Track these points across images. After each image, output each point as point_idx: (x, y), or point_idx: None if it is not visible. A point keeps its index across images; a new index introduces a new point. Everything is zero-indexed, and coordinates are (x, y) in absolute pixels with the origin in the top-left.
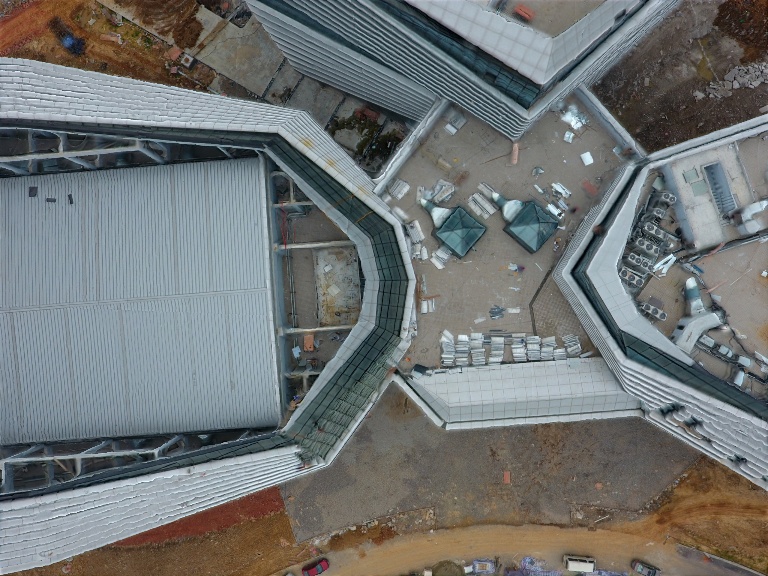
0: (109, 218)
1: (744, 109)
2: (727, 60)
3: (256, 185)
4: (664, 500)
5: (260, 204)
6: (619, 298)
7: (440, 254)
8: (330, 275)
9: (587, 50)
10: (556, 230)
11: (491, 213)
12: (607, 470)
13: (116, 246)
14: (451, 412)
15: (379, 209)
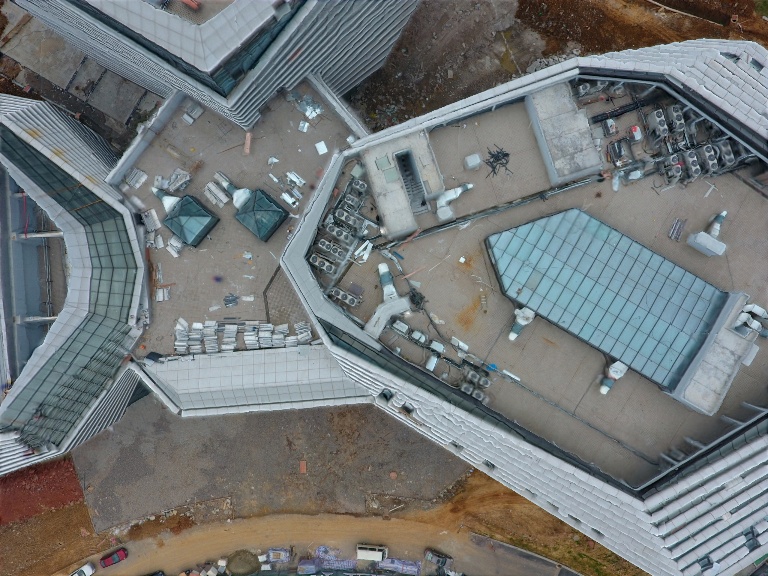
0: None
1: None
2: (529, 52)
3: None
4: (458, 489)
5: None
6: (308, 284)
7: (173, 242)
8: None
9: (268, 38)
10: (290, 218)
11: (224, 202)
12: (402, 459)
13: None
14: (182, 399)
15: (107, 198)
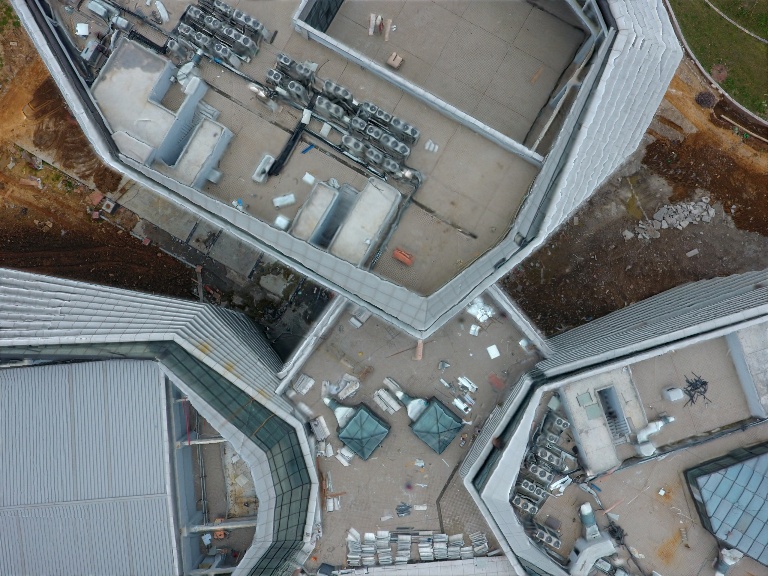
0: (6, 420)
1: (671, 253)
2: (656, 198)
3: (156, 386)
4: None
5: (160, 406)
6: (512, 527)
7: (345, 452)
8: (238, 465)
9: None
10: (463, 425)
11: (396, 410)
12: None
13: (13, 450)
14: None
15: (280, 412)
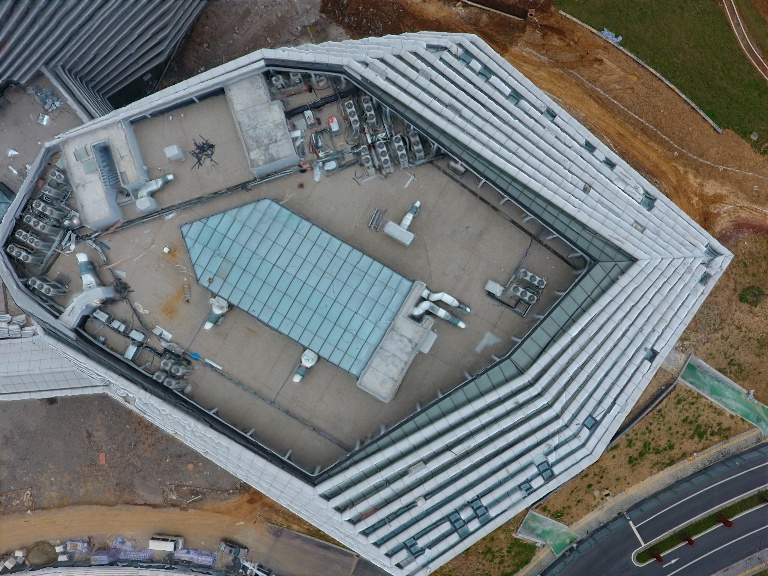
0: None
1: None
2: None
3: None
4: None
5: None
6: (4, 273)
7: None
8: None
9: None
10: None
11: None
12: None
13: None
14: None
15: None
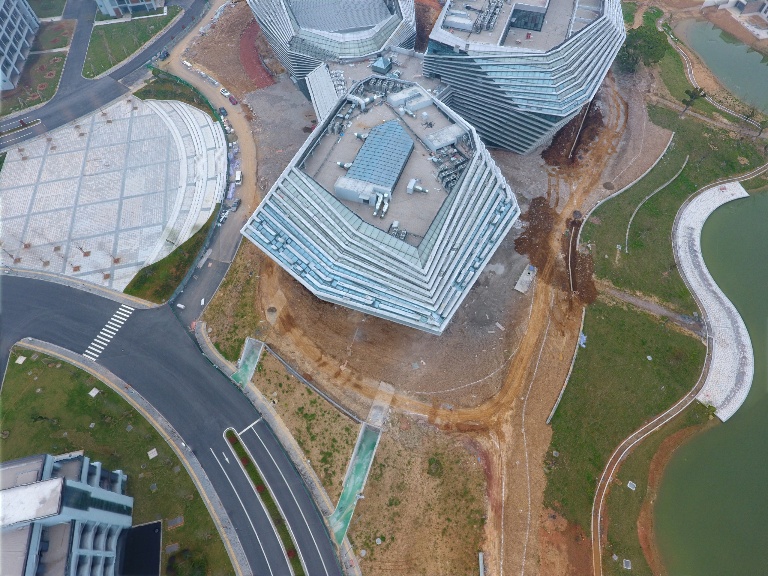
0: None
1: None
2: None
3: None
4: None
5: None
6: None
7: None
8: None
9: None
10: None
11: None
12: None
13: (356, 0)
14: None
15: (385, 45)
